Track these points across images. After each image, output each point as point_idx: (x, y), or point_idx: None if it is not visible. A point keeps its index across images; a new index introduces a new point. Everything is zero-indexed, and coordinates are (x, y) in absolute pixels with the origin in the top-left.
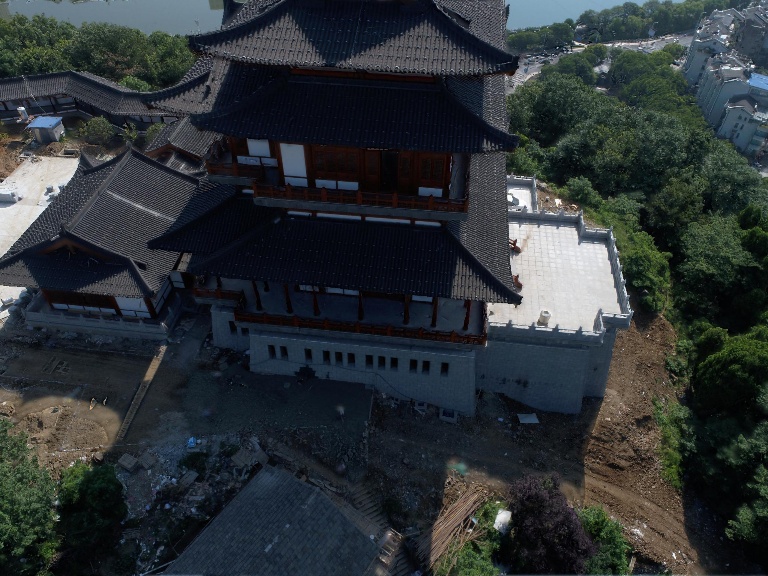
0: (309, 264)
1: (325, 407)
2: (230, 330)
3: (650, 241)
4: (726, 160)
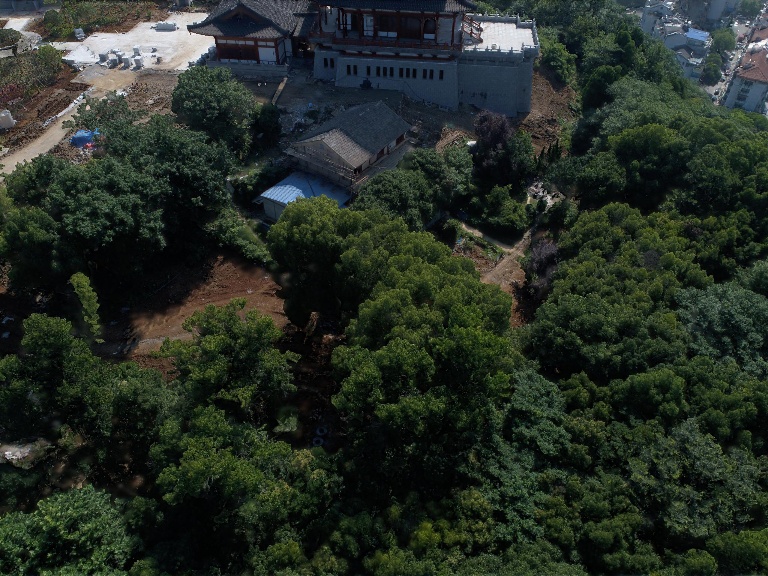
0: (374, 0)
1: (378, 97)
2: (324, 65)
3: (563, 47)
4: (613, 7)
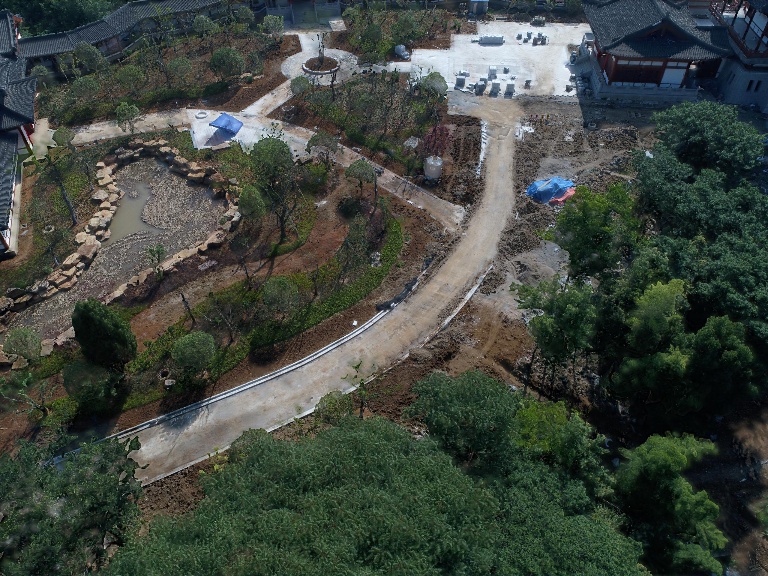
0: None
1: None
2: (747, 88)
3: None
4: None
